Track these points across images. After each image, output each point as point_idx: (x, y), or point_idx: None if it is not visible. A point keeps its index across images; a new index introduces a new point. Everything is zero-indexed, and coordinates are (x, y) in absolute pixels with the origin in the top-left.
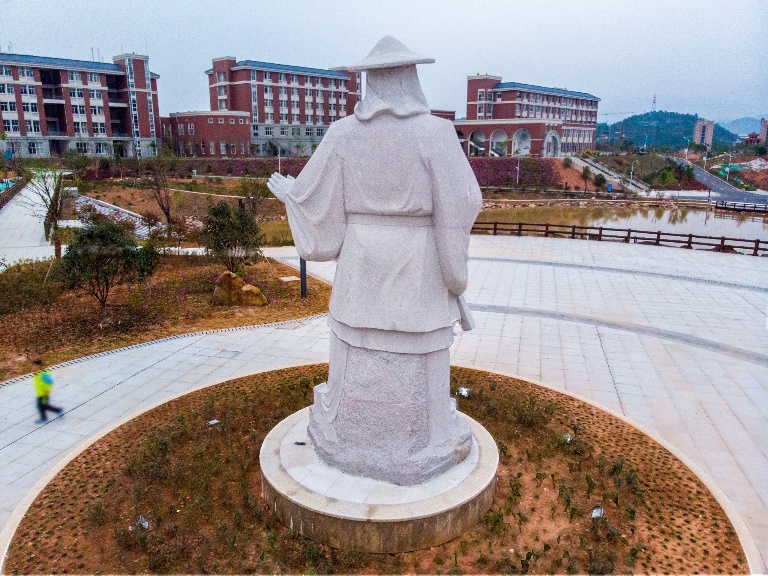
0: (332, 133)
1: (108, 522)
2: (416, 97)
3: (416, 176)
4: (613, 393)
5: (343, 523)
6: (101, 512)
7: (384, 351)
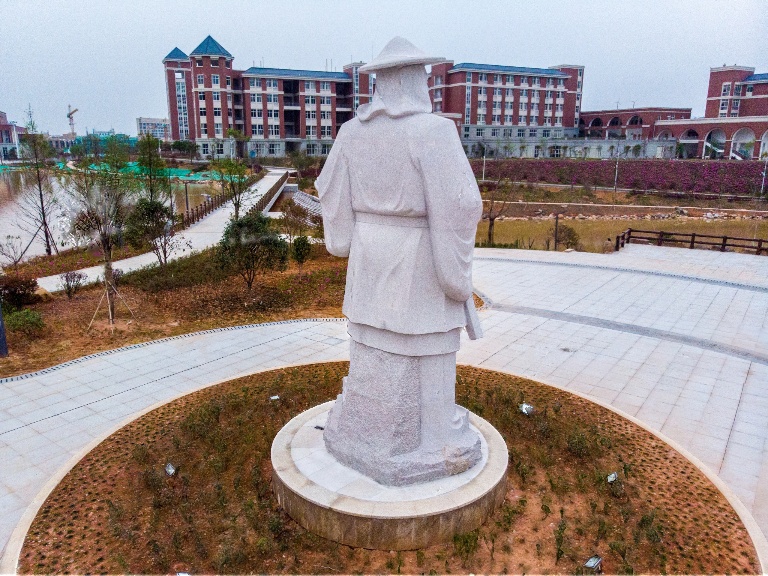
0: (341, 134)
1: (148, 463)
2: (418, 97)
3: (407, 176)
4: (722, 440)
5: (311, 506)
6: (145, 454)
7: (378, 349)
